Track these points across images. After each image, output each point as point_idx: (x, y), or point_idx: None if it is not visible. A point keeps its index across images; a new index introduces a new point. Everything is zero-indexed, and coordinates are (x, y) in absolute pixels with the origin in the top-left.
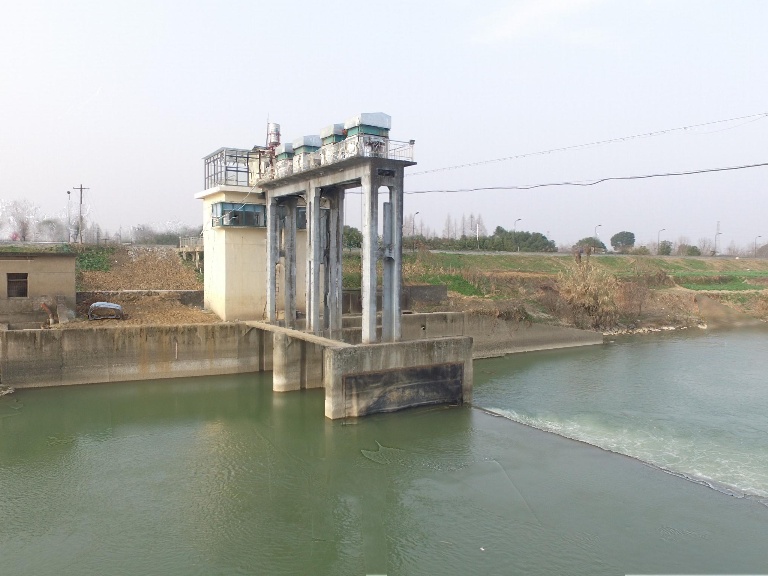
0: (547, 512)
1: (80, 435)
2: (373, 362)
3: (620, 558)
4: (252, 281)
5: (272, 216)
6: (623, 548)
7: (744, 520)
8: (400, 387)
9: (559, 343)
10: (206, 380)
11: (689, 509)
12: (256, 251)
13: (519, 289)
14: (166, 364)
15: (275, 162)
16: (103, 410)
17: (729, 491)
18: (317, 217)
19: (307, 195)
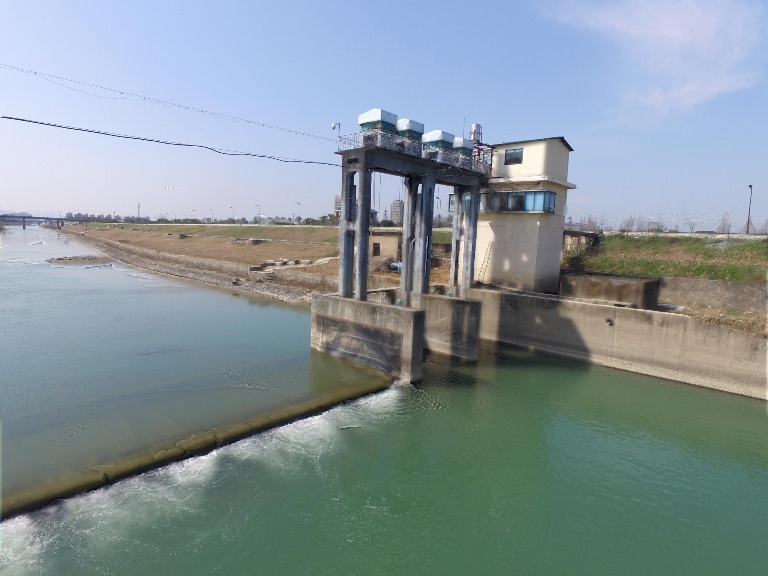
0: (136, 396)
1: None
2: (334, 310)
3: (55, 411)
4: None
5: (456, 202)
6: (68, 413)
7: (74, 462)
8: (350, 336)
9: None
10: None
11: (111, 441)
12: None
13: None
14: None
15: (495, 155)
16: None
17: (168, 483)
18: (407, 201)
19: None
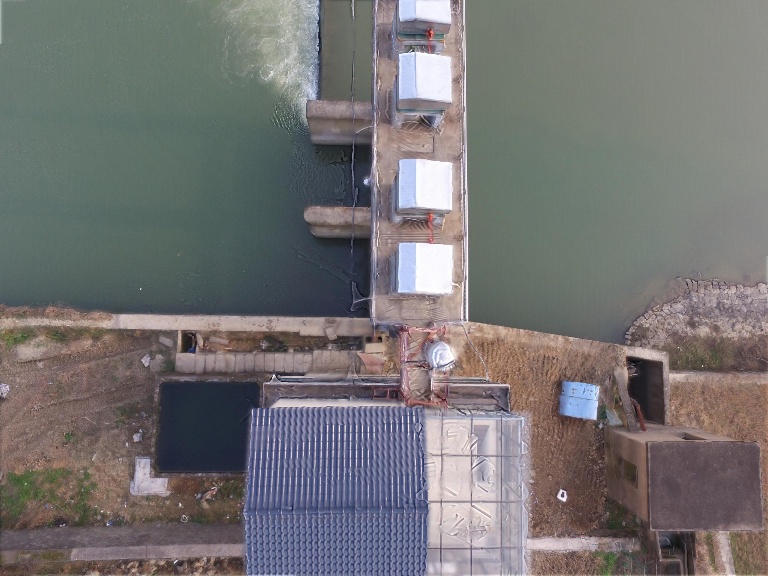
0: None
1: None
2: None
3: None
4: None
5: None
6: None
7: None
8: None
9: None
10: None
11: None
12: None
13: None
14: None
15: None
16: None
17: None
18: None
19: None
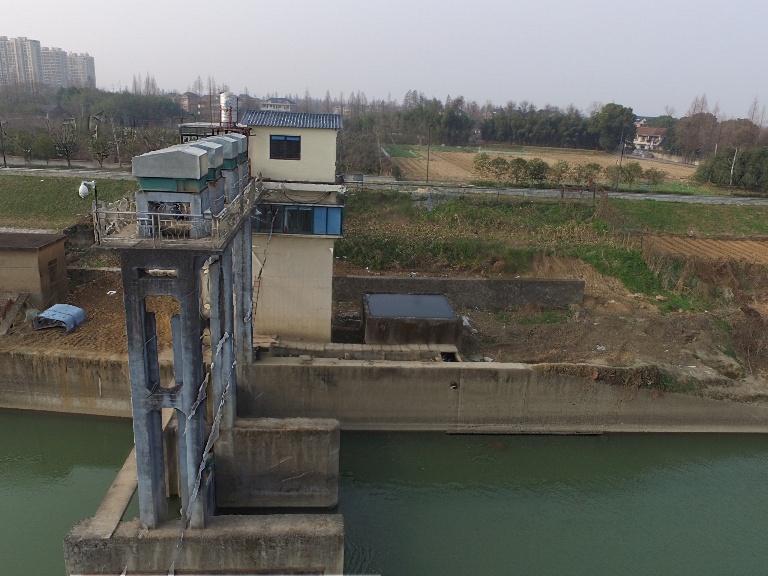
0: None
1: (13, 456)
2: (140, 559)
3: None
4: None
5: None
6: None
7: None
8: None
9: (718, 425)
10: None
11: None
12: None
13: (724, 290)
14: (90, 399)
15: (253, 140)
16: (30, 436)
17: None
18: None
19: None
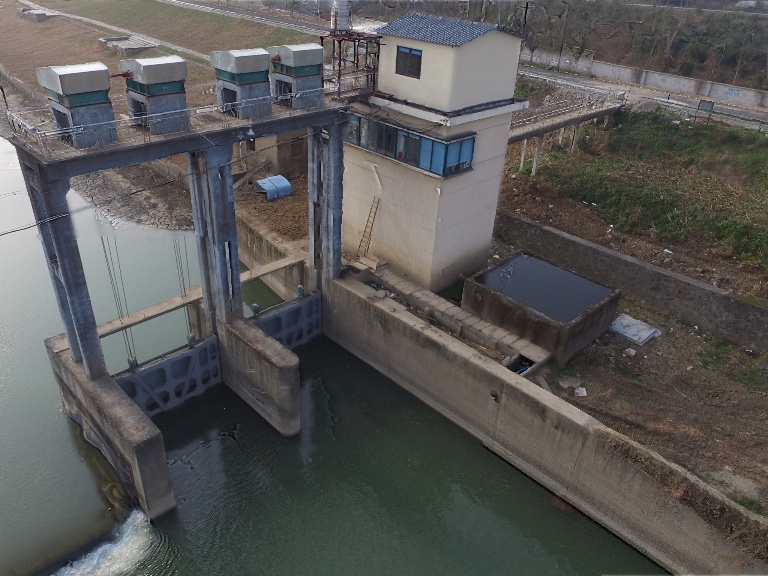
0: None
1: None
2: None
3: None
4: (352, 208)
5: (310, 141)
6: None
7: None
8: None
9: None
10: (269, 291)
11: None
12: (357, 173)
13: None
14: None
15: (383, 50)
16: None
17: None
18: None
19: None
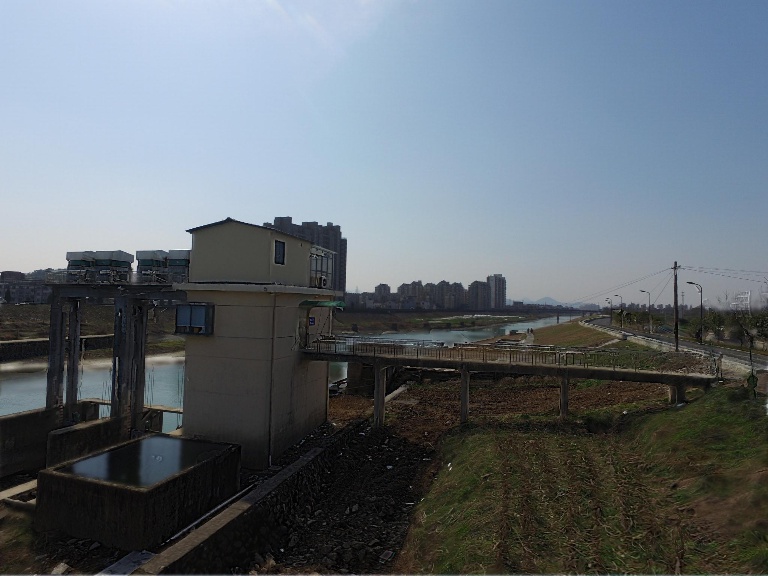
0: None
1: None
2: None
3: None
4: None
5: None
6: None
7: None
8: None
9: None
10: None
11: None
12: None
13: None
14: None
15: None
16: None
17: None
18: None
19: (147, 303)
